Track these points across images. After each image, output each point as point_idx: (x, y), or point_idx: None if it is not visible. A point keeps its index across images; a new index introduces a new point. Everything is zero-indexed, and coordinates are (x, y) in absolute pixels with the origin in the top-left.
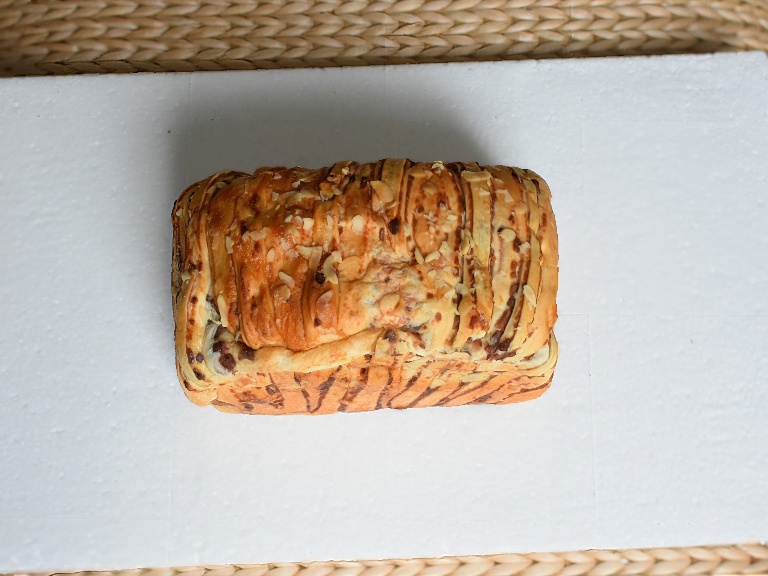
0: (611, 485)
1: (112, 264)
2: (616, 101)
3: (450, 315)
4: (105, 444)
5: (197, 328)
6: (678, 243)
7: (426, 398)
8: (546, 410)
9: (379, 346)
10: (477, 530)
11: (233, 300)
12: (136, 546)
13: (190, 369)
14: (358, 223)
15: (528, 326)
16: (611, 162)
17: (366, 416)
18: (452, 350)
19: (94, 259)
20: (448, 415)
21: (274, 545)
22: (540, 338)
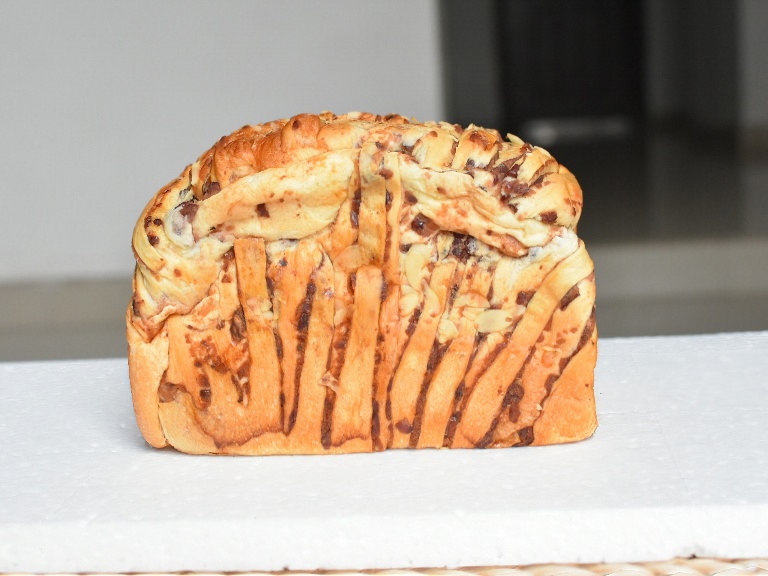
0: (707, 477)
1: (81, 410)
2: (668, 347)
3: (448, 139)
4: (6, 472)
5: (163, 208)
6: (759, 384)
7: (436, 383)
8: (606, 450)
9: (364, 148)
10: (508, 502)
11: (209, 157)
12: (2, 516)
13: (144, 233)
14: (354, 114)
15: (540, 158)
16: (668, 363)
17: (359, 457)
18: (451, 169)
19: (62, 409)
20: (471, 453)
21: (202, 514)
22: (559, 191)
